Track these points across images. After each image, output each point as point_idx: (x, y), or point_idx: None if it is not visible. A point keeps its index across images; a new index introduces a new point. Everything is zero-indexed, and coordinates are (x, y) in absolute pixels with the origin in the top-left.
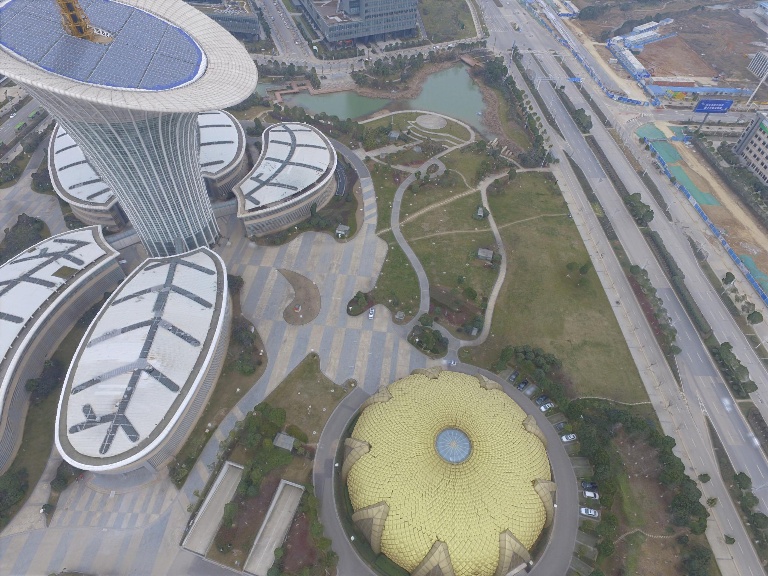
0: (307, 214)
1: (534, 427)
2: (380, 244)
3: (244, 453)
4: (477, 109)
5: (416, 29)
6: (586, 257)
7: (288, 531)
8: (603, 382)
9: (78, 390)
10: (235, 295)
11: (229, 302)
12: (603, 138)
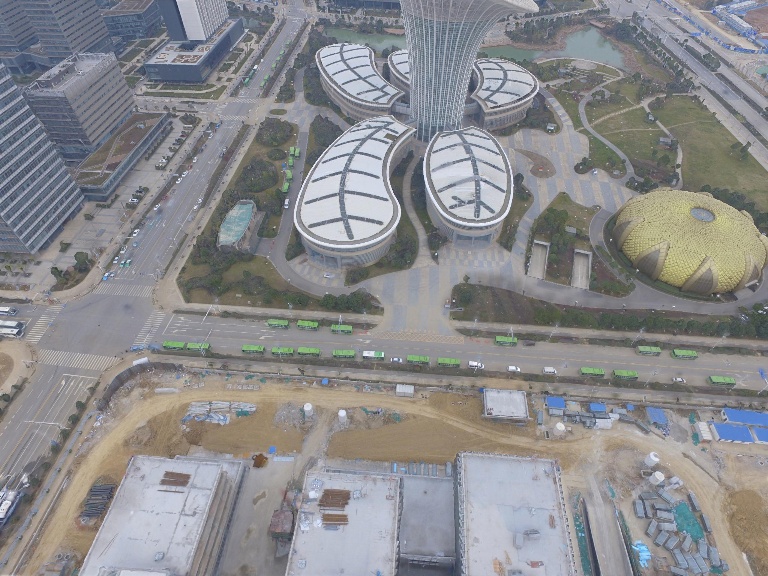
0: (520, 118)
1: None
2: (581, 136)
3: (543, 237)
4: (616, 57)
5: None
6: None
7: (592, 270)
8: None
9: (442, 190)
10: None
11: None
12: (730, 75)
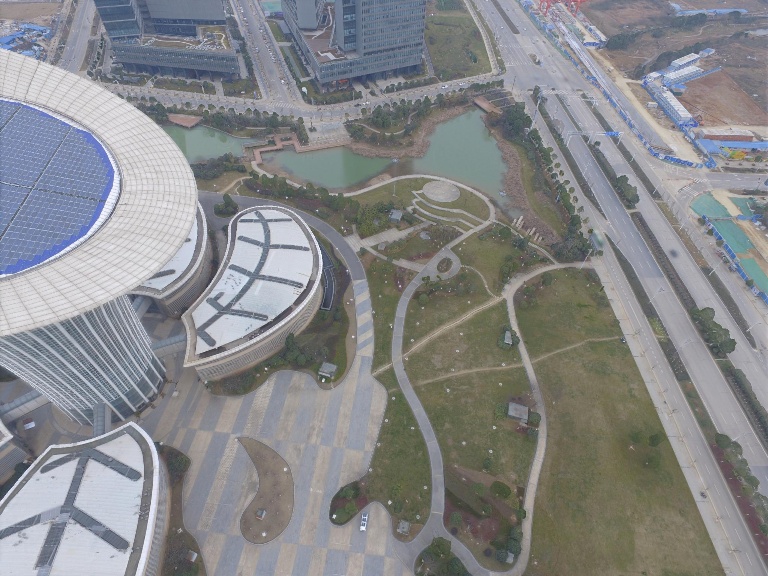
0: (282, 343)
1: None
2: (377, 391)
3: None
4: (496, 172)
5: (422, 63)
6: (651, 411)
7: None
8: None
9: None
10: (176, 487)
11: (165, 504)
12: (652, 216)
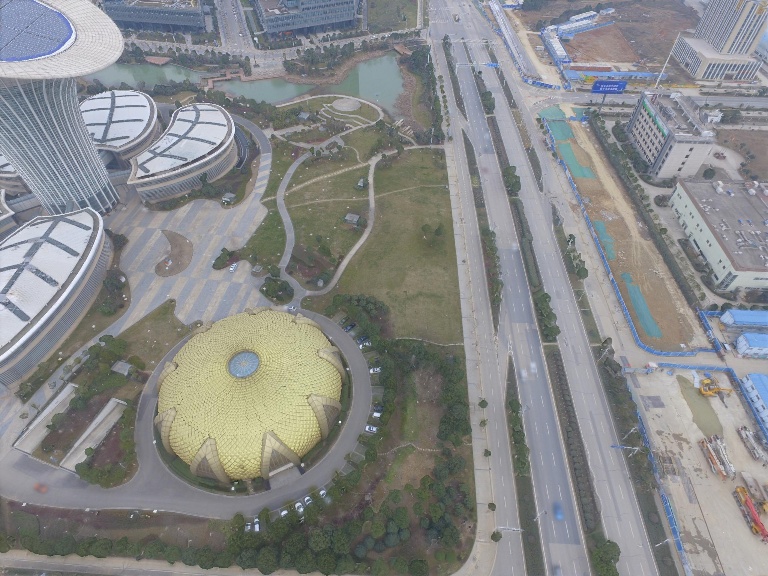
0: (201, 184)
1: (326, 354)
2: (261, 210)
3: (87, 377)
4: None
5: (358, 21)
6: (449, 222)
7: (105, 437)
8: (425, 326)
9: None
10: (117, 251)
11: (108, 256)
12: (504, 118)
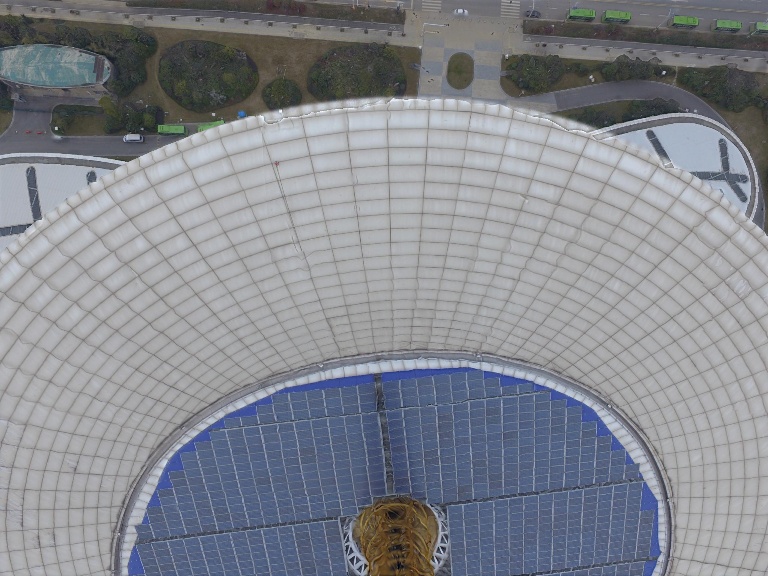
0: None
1: None
2: None
3: None
4: None
5: None
6: None
7: None
8: None
9: None
10: None
11: None
12: None
